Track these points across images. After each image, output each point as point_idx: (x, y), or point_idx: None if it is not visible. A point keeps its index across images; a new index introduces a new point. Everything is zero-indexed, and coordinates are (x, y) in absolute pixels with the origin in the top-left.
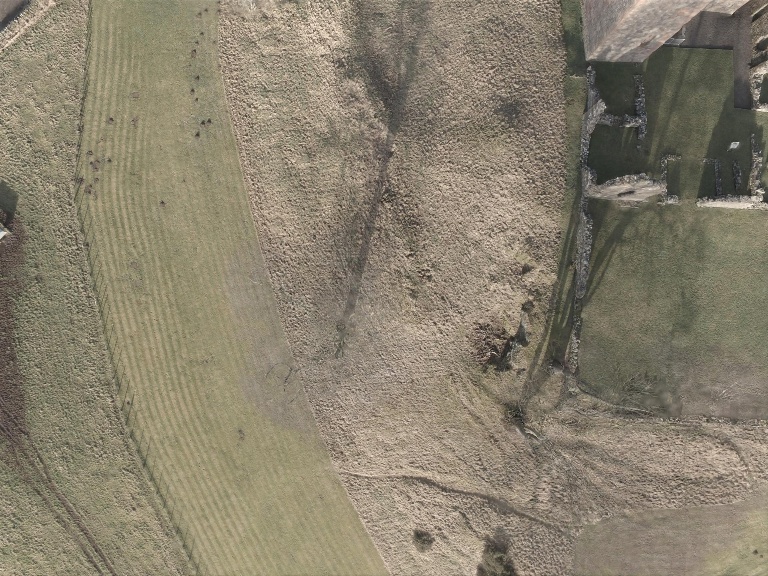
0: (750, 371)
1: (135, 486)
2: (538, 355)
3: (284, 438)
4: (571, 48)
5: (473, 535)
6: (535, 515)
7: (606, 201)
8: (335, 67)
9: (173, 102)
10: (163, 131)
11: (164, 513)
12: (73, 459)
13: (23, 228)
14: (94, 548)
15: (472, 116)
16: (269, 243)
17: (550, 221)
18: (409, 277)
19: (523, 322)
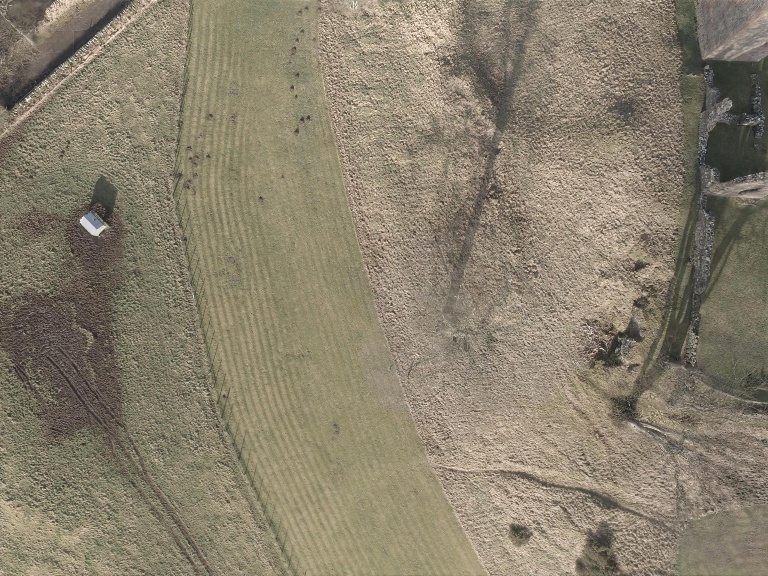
0: None
1: (229, 479)
2: (653, 351)
3: (379, 432)
4: (686, 47)
5: (575, 529)
6: (639, 510)
7: (724, 198)
8: (440, 65)
9: (272, 99)
10: (262, 127)
11: (258, 506)
12: (169, 451)
13: (122, 222)
14: (187, 540)
15: (584, 114)
16: (367, 239)
17: (667, 218)
18: (515, 273)
19: (636, 318)
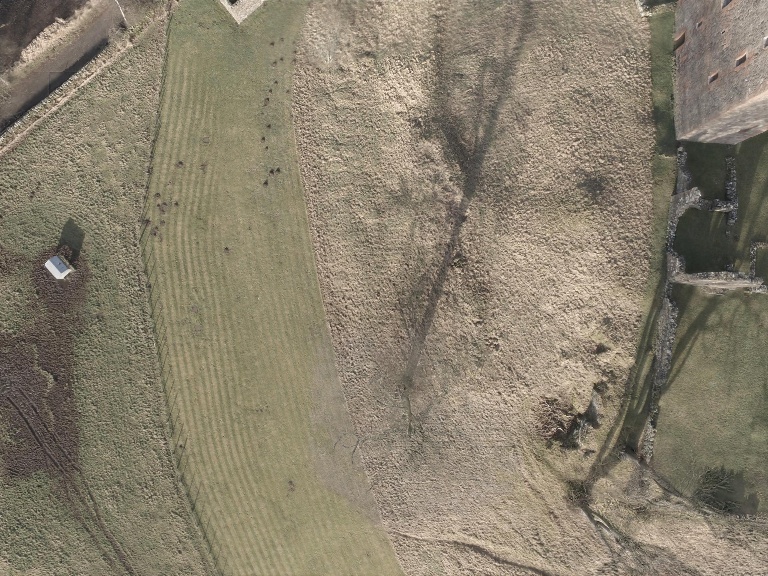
0: None
1: (182, 529)
2: (610, 439)
3: (334, 493)
4: (661, 125)
5: None
6: None
7: (691, 287)
8: (411, 126)
9: (243, 149)
10: (231, 177)
11: (209, 558)
12: (123, 498)
13: (88, 266)
14: None
15: (552, 188)
16: (331, 296)
17: (631, 303)
18: (476, 345)
19: (595, 403)
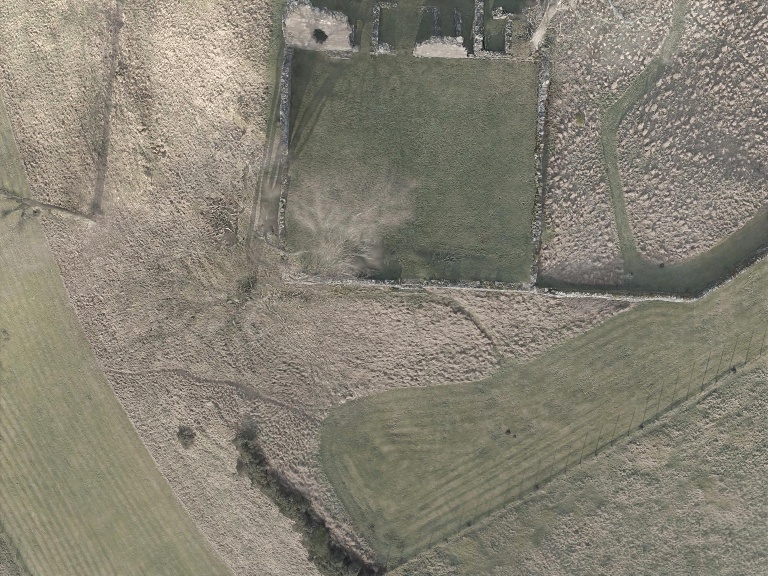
0: (475, 231)
1: None
2: (253, 221)
3: (48, 337)
4: None
5: (224, 425)
6: (281, 400)
7: (315, 52)
8: None
9: None
10: None
11: None
12: None
13: None
14: None
15: None
16: (22, 133)
17: (257, 76)
18: (143, 154)
19: None
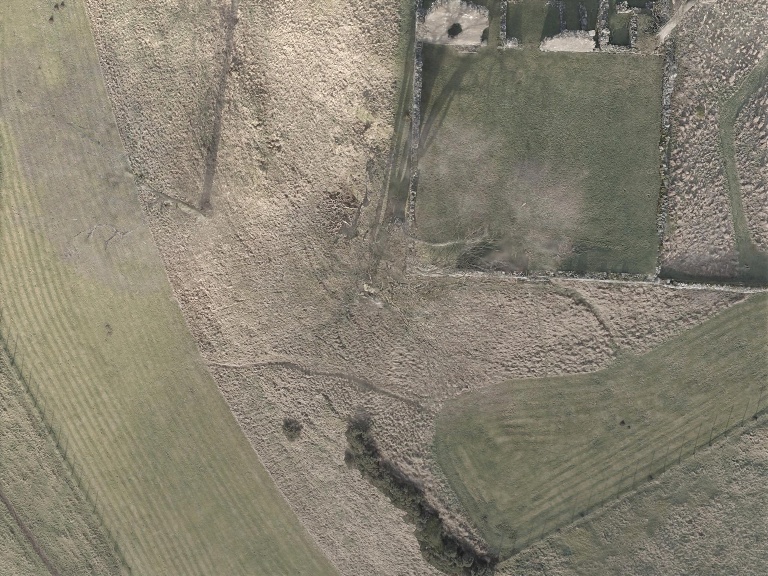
0: (600, 223)
1: (5, 386)
2: (379, 214)
3: (152, 331)
4: None
5: (335, 417)
6: (395, 392)
7: (443, 47)
8: None
9: None
10: (16, 17)
11: (36, 413)
12: None
13: None
14: None
15: None
16: (128, 129)
17: (385, 70)
18: (258, 148)
19: (366, 182)
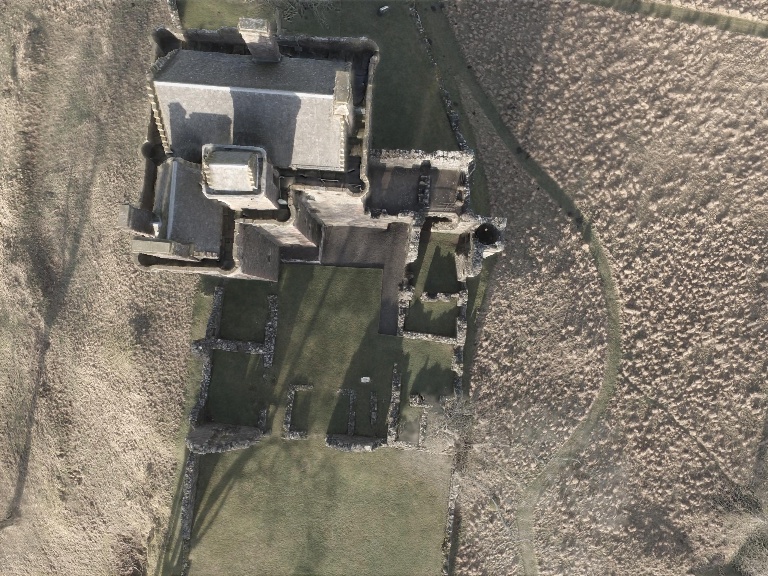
0: None
1: None
2: None
3: None
4: None
5: None
6: None
7: None
8: (4, 246)
9: None
10: None
11: None
12: None
13: None
14: None
15: (114, 320)
16: None
17: (167, 450)
18: (60, 478)
19: None
